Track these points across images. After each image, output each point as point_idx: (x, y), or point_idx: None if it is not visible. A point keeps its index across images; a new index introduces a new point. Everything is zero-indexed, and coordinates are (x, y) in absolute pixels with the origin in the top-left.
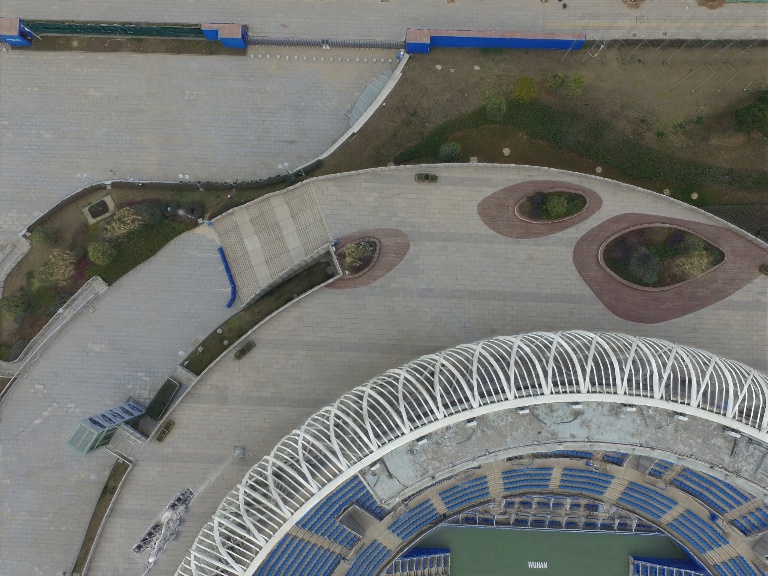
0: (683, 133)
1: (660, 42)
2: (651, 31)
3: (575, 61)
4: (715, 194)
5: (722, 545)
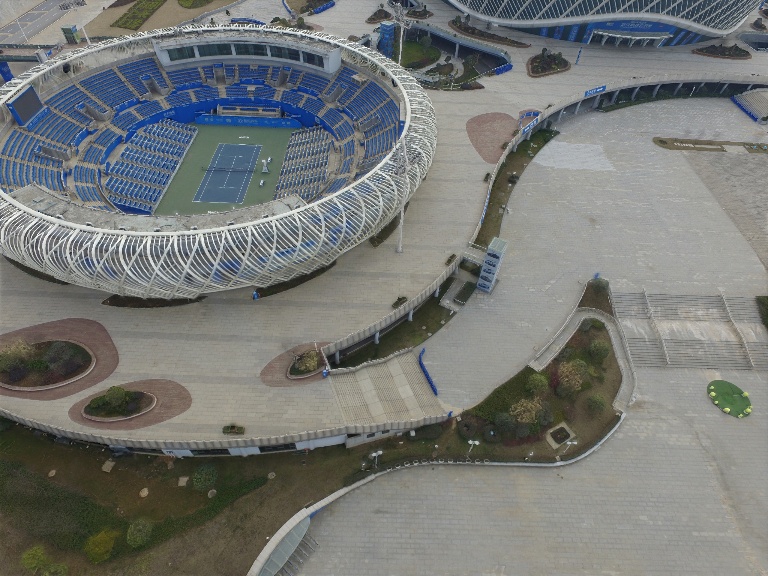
0: None
1: None
2: None
3: None
4: None
5: (92, 206)
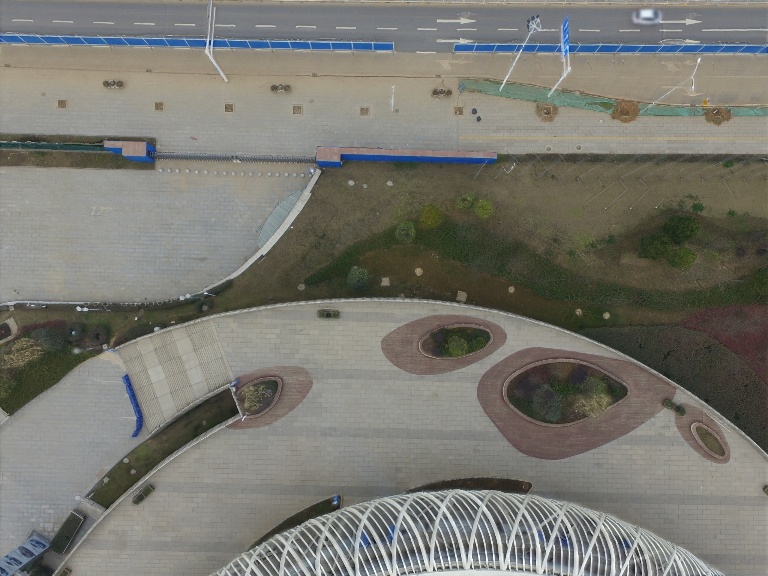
0: (595, 253)
1: (574, 156)
2: (565, 145)
3: (489, 177)
4: (626, 314)
5: None
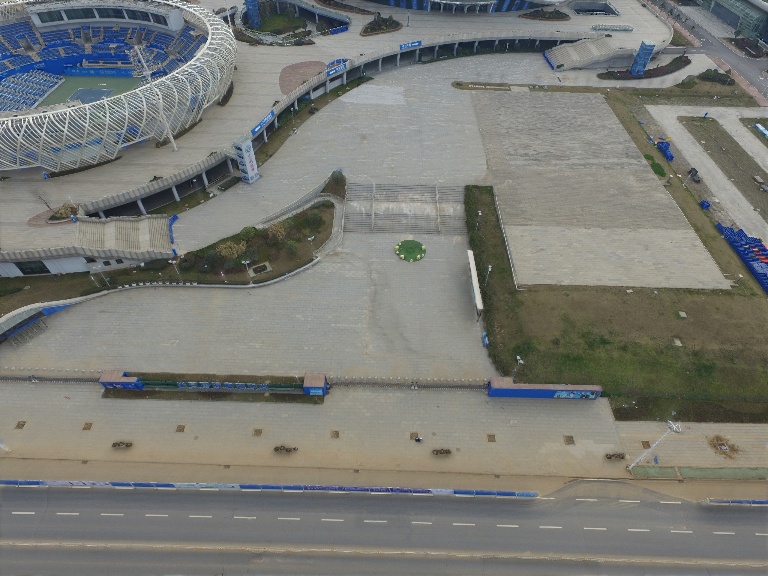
0: None
1: None
2: None
3: None
4: None
5: None
